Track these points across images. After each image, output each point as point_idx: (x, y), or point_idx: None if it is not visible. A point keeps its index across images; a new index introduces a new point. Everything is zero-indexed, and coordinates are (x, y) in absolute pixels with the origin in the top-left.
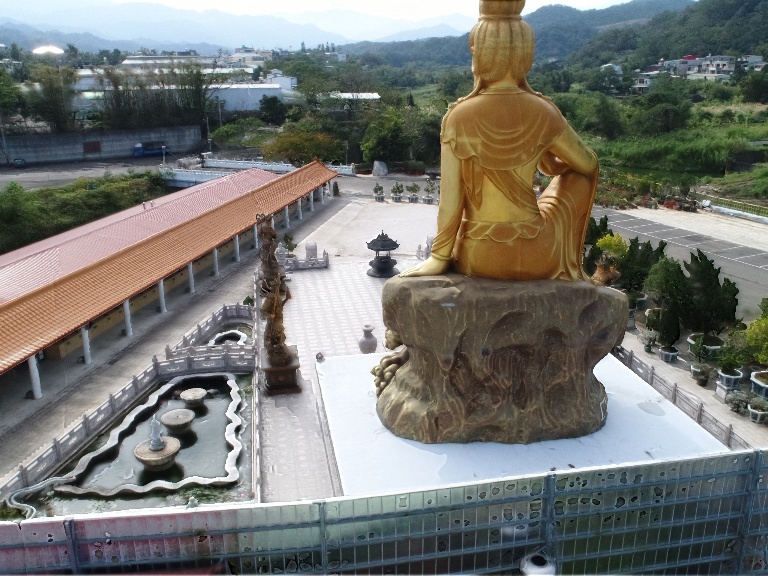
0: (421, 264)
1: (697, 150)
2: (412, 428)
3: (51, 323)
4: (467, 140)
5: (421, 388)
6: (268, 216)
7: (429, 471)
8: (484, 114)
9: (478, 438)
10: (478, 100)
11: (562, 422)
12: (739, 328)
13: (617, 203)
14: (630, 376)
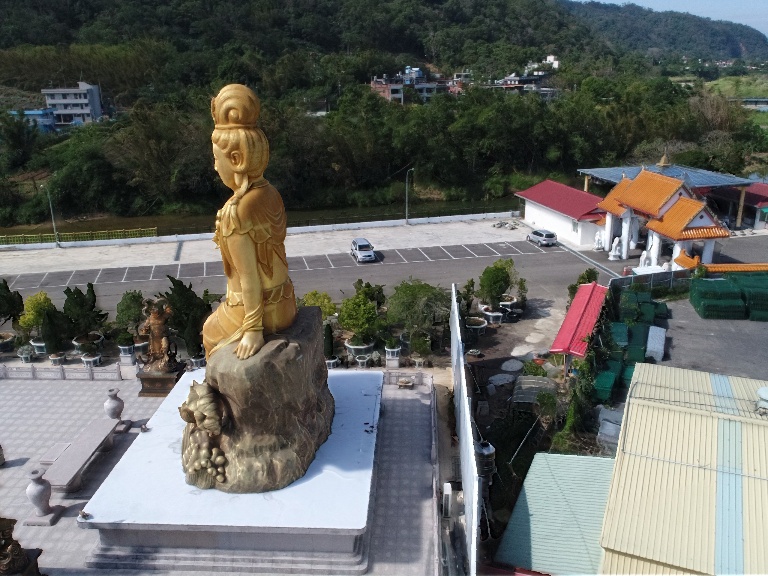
0: (249, 341)
1: None
2: (292, 473)
3: None
4: (262, 227)
5: (277, 441)
6: None
7: (342, 482)
8: (266, 203)
9: (315, 449)
10: (257, 193)
11: (331, 407)
12: None
13: None
14: None
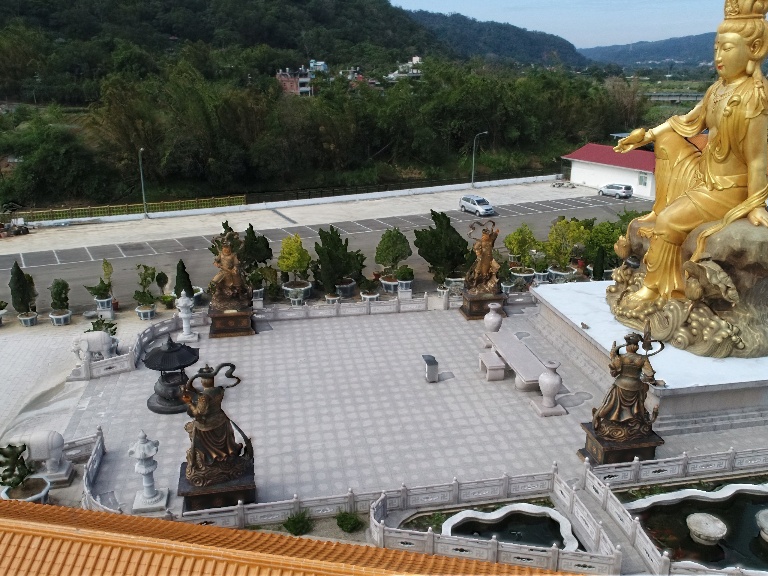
0: (767, 215)
1: None
2: None
3: None
4: None
5: None
6: (209, 369)
7: None
8: None
9: None
10: None
11: None
12: None
13: None
14: (607, 282)
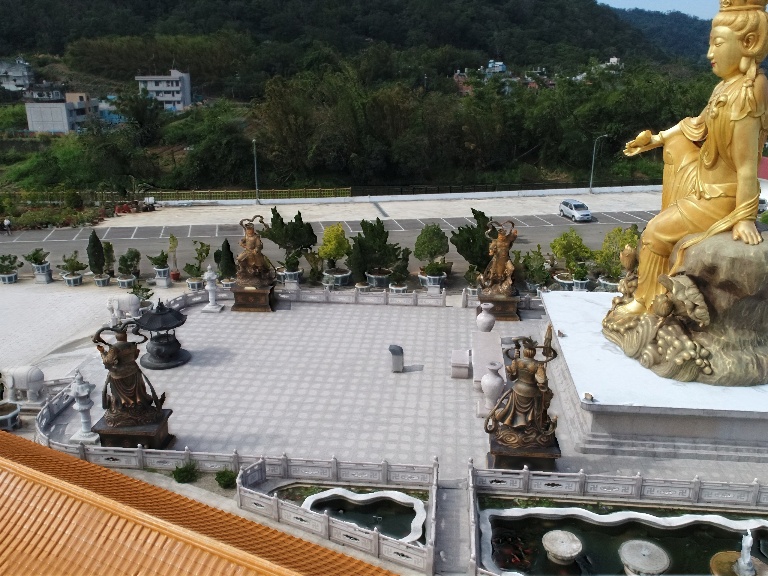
0: (751, 229)
1: None
2: None
3: None
4: None
5: None
6: None
7: None
8: None
9: None
10: None
11: None
12: None
13: (87, 219)
14: None
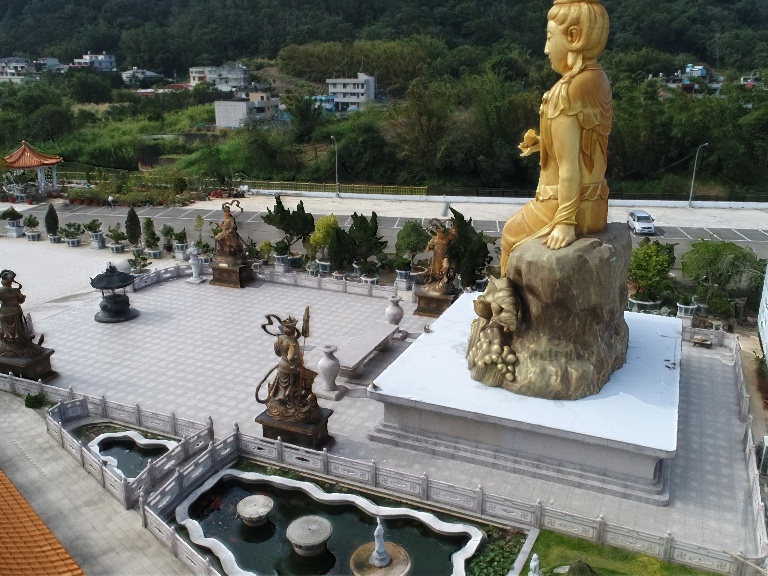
0: (561, 233)
1: (106, 149)
2: (586, 386)
3: (1, 524)
4: (592, 111)
5: (574, 349)
6: (6, 273)
7: (643, 406)
8: (598, 87)
9: None
10: (590, 75)
11: None
12: (490, 260)
13: (178, 200)
14: None
